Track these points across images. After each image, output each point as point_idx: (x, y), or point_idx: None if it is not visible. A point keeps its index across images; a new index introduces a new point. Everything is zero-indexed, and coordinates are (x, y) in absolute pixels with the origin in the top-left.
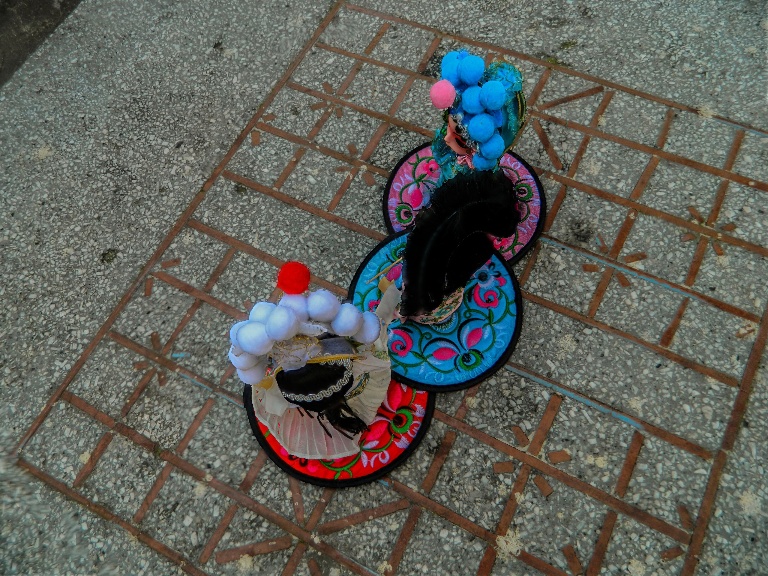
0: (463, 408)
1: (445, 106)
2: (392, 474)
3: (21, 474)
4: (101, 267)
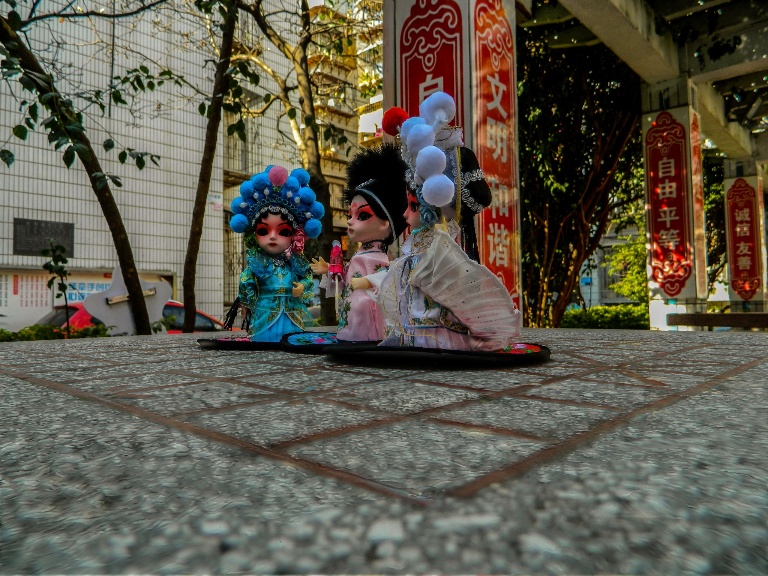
0: None
1: None
2: None
3: (509, 492)
4: None
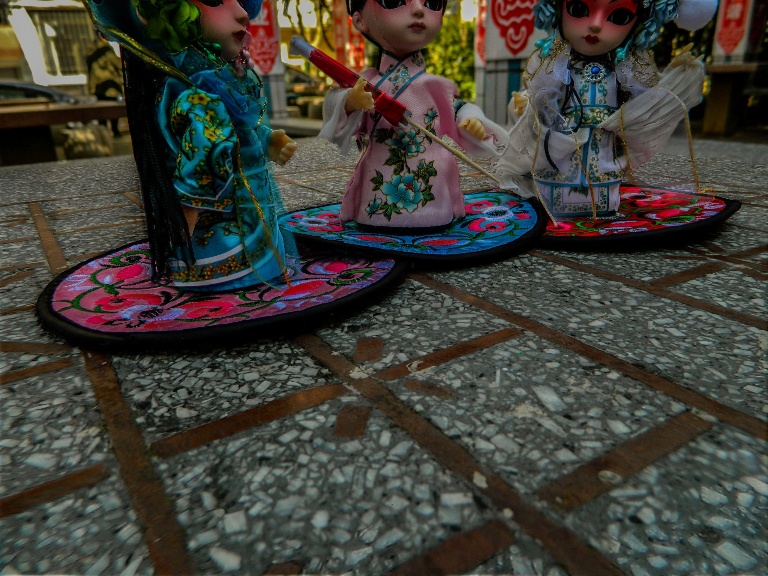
0: None
1: None
2: None
3: None
4: None
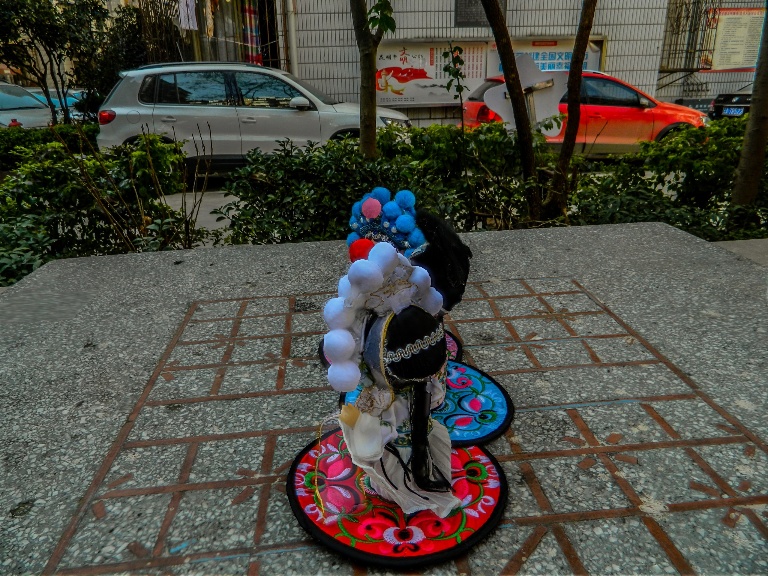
0: (514, 445)
1: (377, 212)
2: (506, 515)
3: None
4: (14, 522)
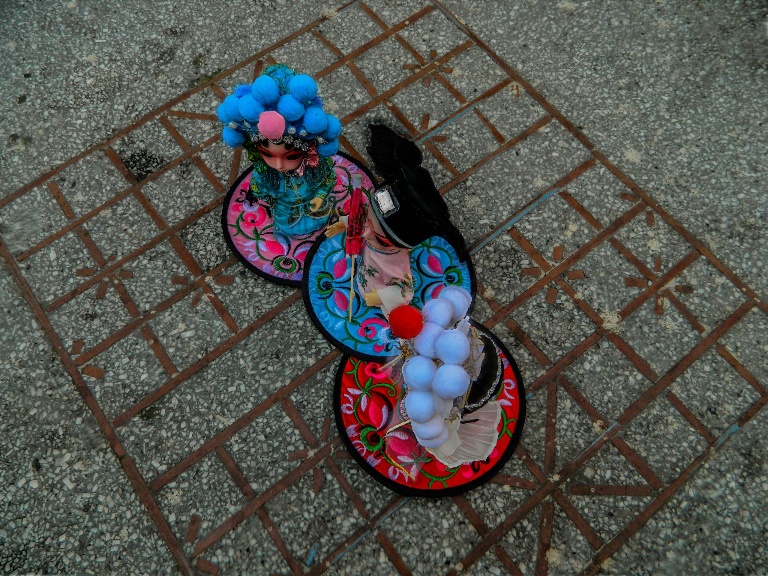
0: (491, 303)
1: None
2: (524, 386)
3: None
4: None
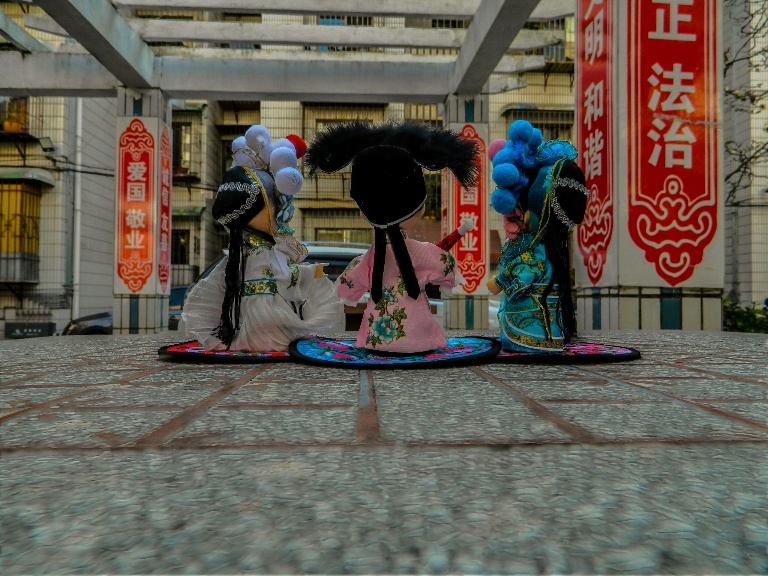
0: None
1: (491, 151)
2: None
3: None
4: None
